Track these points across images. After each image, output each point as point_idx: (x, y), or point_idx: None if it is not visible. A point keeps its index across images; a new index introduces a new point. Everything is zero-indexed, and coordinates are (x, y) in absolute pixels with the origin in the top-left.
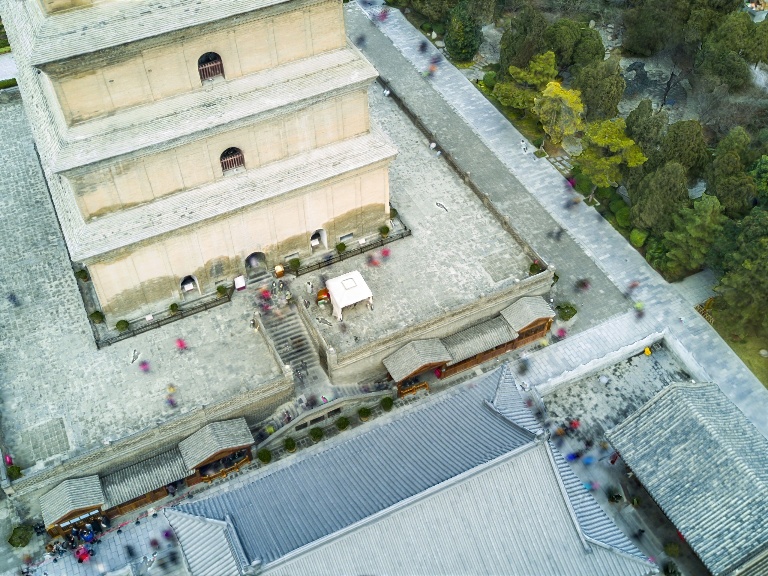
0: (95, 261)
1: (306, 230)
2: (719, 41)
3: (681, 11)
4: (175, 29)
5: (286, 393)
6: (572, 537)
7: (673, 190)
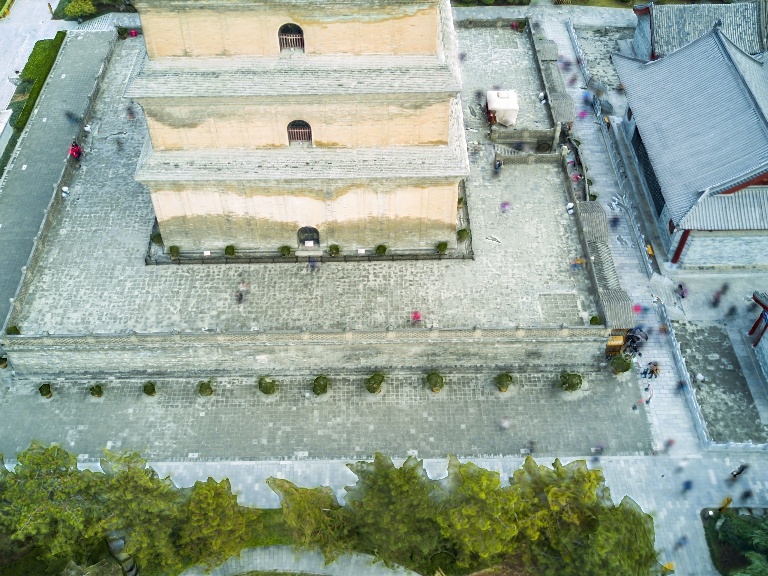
0: None
1: None
2: None
3: None
4: None
5: None
6: (754, 64)
7: None
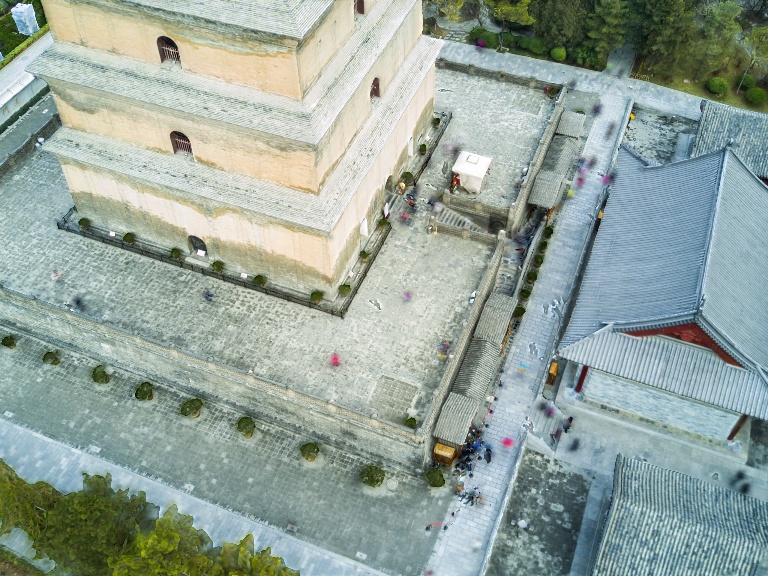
0: None
1: None
2: None
3: None
4: None
5: None
6: None
7: (575, 4)
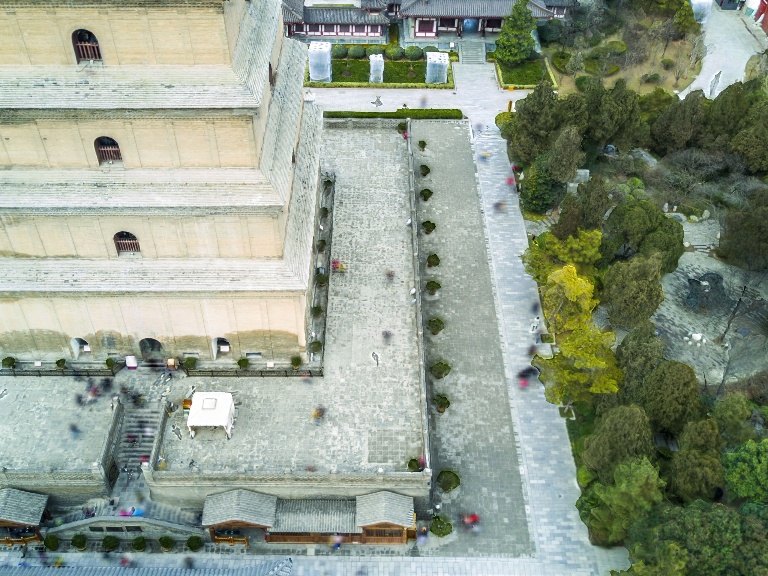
0: None
1: (206, 334)
2: None
3: None
4: (60, 107)
5: (98, 489)
6: None
7: (627, 438)
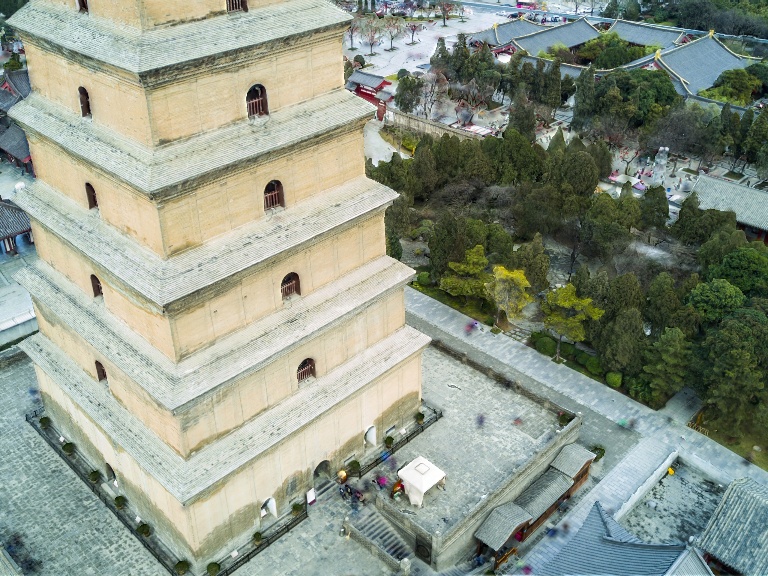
0: (195, 499)
1: (361, 430)
2: (597, 217)
3: (556, 200)
4: (274, 254)
5: None
6: None
7: (636, 332)
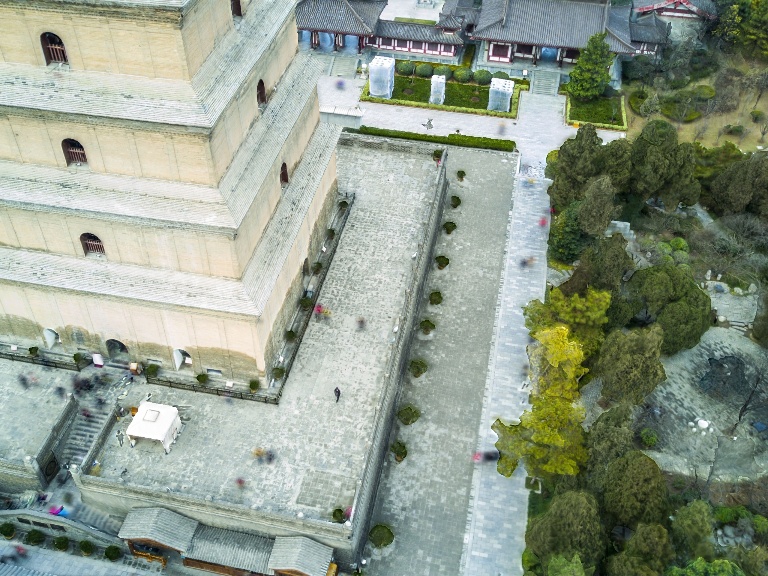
0: None
1: (168, 344)
2: None
3: None
4: (24, 106)
5: (33, 481)
6: None
7: (571, 528)
